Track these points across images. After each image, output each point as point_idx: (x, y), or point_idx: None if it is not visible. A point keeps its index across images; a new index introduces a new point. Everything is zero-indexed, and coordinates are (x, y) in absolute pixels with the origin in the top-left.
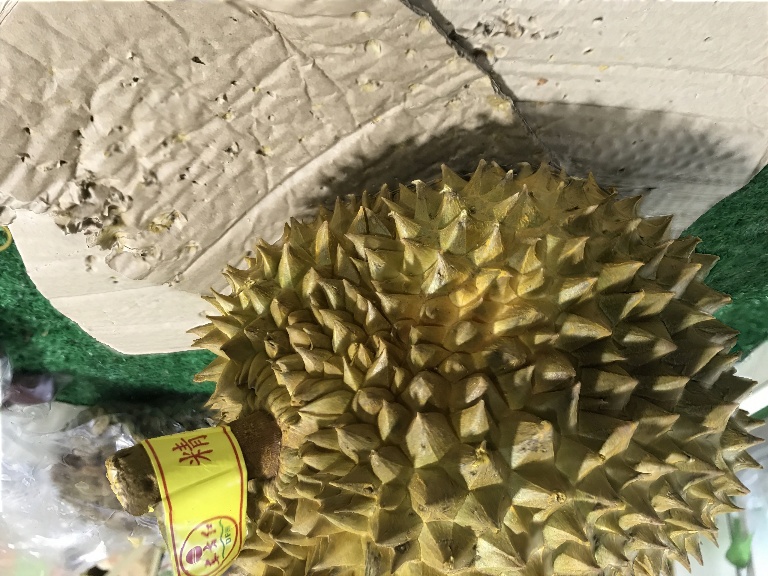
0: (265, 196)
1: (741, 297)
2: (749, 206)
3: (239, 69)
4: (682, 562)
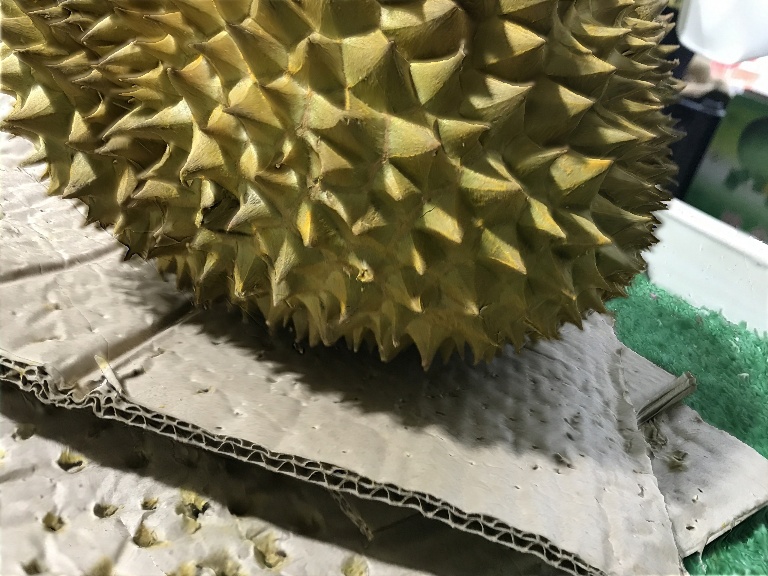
0: (63, 268)
1: (759, 372)
2: None
3: (11, 193)
4: None
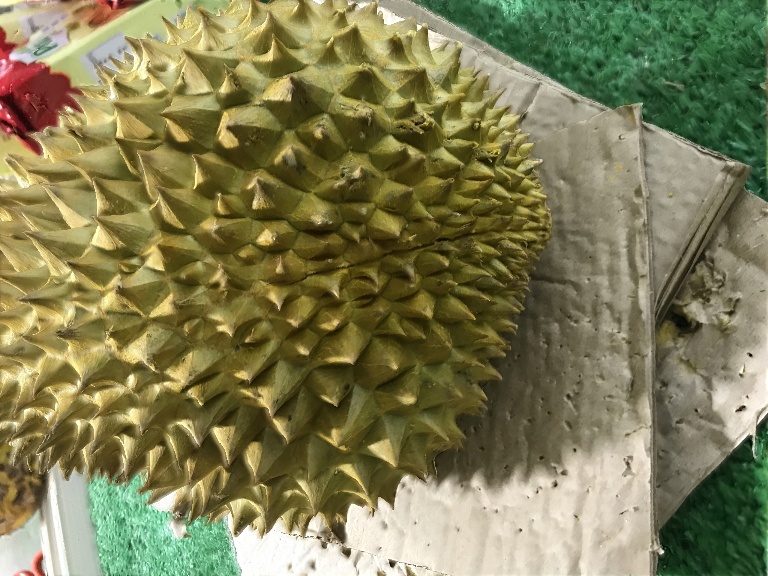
0: None
1: None
2: (616, 8)
3: None
4: (143, 51)
